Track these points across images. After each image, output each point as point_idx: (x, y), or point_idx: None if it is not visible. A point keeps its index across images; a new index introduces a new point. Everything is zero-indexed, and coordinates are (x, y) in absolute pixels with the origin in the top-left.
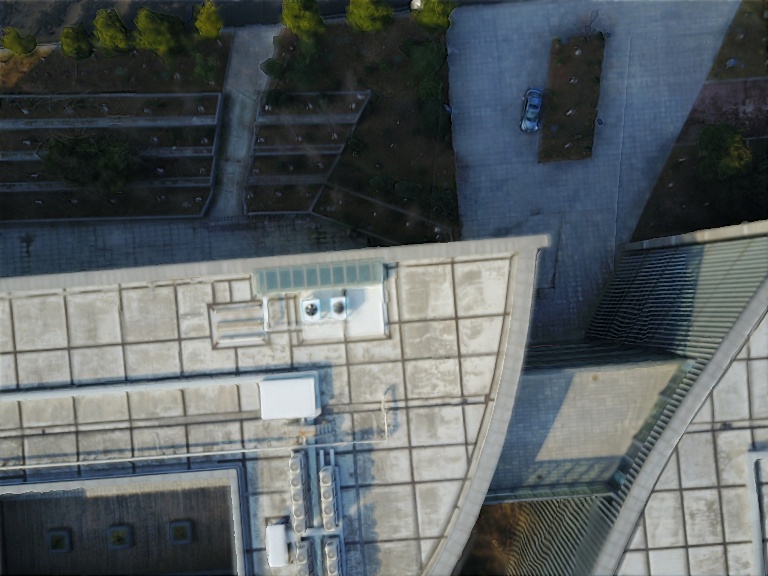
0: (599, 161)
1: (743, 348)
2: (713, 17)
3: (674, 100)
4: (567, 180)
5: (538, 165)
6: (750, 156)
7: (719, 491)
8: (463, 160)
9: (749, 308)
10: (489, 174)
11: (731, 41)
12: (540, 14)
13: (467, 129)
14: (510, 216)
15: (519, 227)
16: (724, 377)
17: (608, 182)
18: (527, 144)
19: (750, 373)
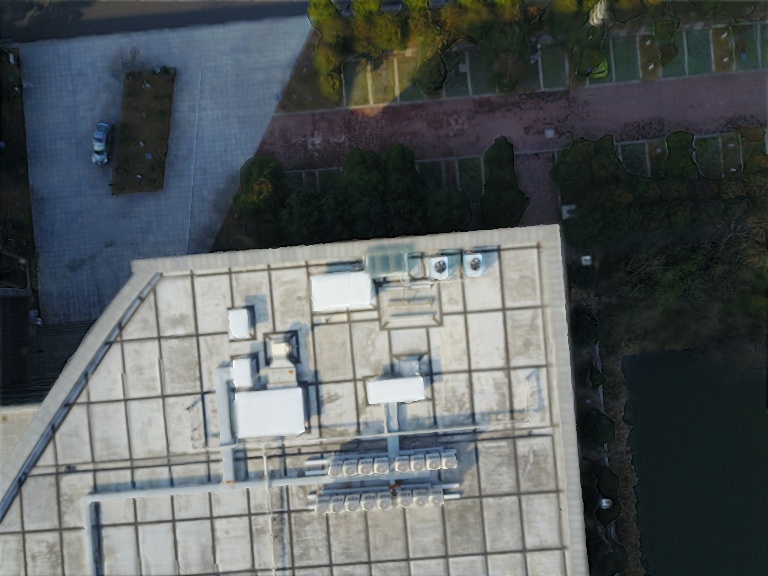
0: (171, 193)
1: (83, 392)
2: (282, 50)
3: (244, 132)
4: (140, 212)
5: (112, 197)
6: (270, 190)
7: (61, 533)
8: (39, 192)
9: (75, 353)
10: (64, 206)
11: (299, 74)
12: (112, 48)
13: (43, 162)
14: (85, 248)
15: (93, 258)
16: (65, 420)
17: (180, 213)
18: (101, 176)
19: (91, 416)
